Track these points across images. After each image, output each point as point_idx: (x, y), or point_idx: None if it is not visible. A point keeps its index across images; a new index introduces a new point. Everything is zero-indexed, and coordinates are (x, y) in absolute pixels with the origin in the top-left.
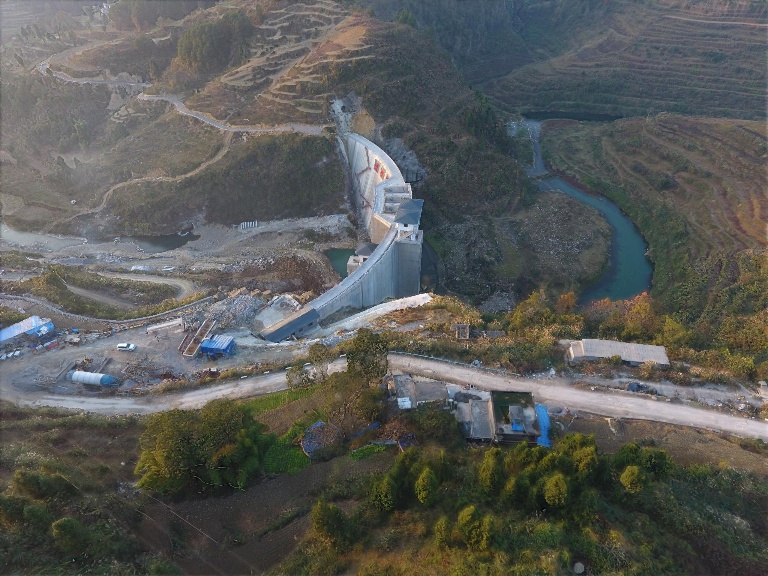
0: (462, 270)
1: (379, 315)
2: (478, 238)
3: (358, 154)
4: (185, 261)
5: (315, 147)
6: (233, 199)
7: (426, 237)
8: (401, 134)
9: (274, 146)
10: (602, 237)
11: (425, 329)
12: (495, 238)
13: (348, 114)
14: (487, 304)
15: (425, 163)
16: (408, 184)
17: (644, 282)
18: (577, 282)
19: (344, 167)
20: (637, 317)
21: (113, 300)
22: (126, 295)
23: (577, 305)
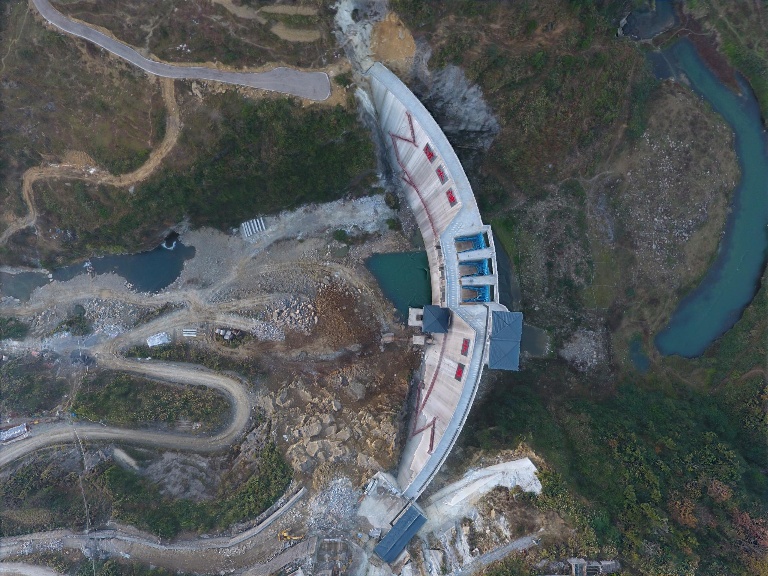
0: (542, 292)
1: (482, 494)
2: (565, 238)
3: (392, 109)
4: (202, 313)
5: (327, 124)
6: (220, 201)
7: (493, 224)
8: (460, 59)
9: (257, 122)
10: (723, 197)
11: (542, 559)
12: (587, 235)
13: (365, 25)
14: (570, 348)
15: (497, 107)
16: (488, 227)
17: (752, 279)
18: (675, 294)
19: (372, 133)
20: (755, 572)
21: (172, 437)
22: (182, 428)
23: (693, 504)
